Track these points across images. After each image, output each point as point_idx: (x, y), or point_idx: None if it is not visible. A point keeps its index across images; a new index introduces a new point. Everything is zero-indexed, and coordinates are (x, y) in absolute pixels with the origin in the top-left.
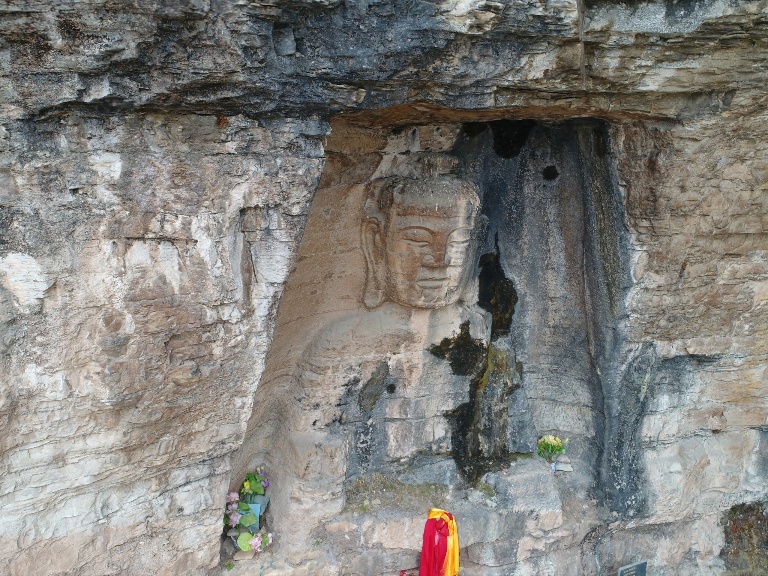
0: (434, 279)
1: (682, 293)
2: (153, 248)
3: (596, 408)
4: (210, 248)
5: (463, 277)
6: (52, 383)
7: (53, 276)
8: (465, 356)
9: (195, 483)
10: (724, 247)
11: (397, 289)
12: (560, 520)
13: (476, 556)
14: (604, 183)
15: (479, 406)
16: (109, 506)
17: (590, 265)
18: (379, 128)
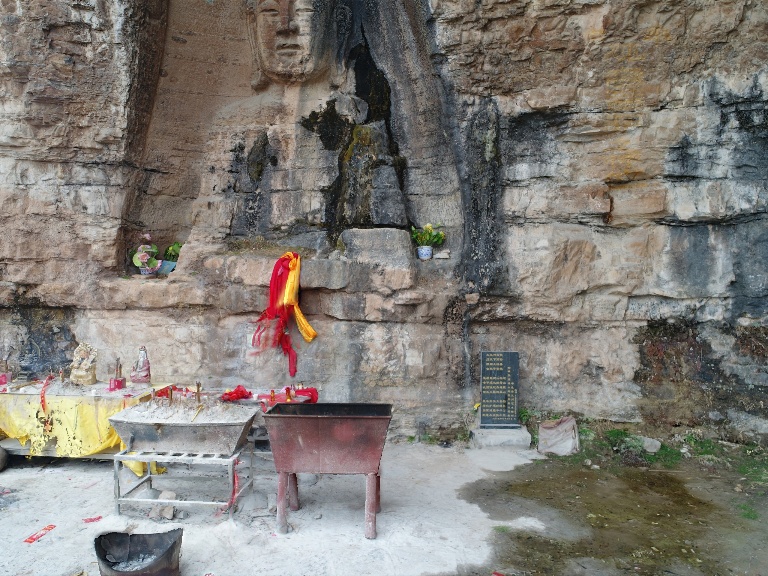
0: (287, 46)
1: (494, 29)
2: None
3: None
4: None
5: (314, 46)
6: None
7: None
8: (332, 130)
9: (95, 187)
10: None
11: (262, 59)
12: (407, 280)
13: (326, 306)
14: None
15: (345, 177)
16: (28, 178)
17: None
18: None
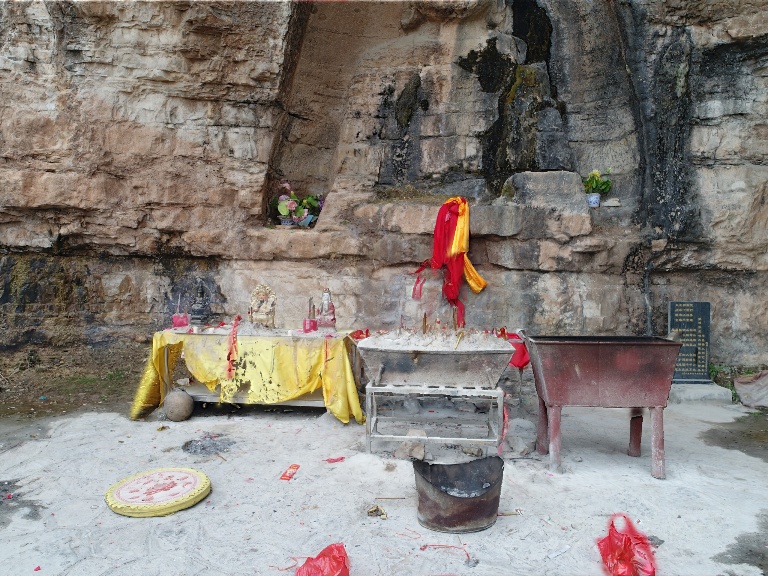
0: None
1: None
2: None
3: (638, 126)
4: None
5: None
6: None
7: None
8: (492, 70)
9: (243, 128)
10: None
11: None
12: (587, 225)
13: (494, 255)
14: None
15: (507, 120)
16: (177, 117)
17: None
18: None
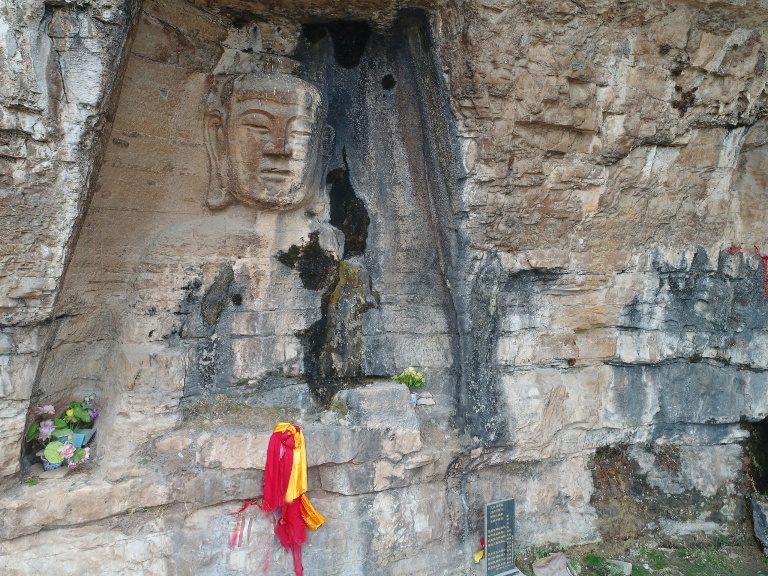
0: (276, 170)
1: (515, 194)
2: None
3: (452, 331)
4: (7, 34)
5: (307, 174)
6: None
7: None
8: (315, 267)
9: None
10: (545, 143)
11: (239, 180)
12: (418, 442)
13: (329, 482)
14: (432, 76)
15: (331, 322)
16: None
17: (430, 170)
18: (217, 13)
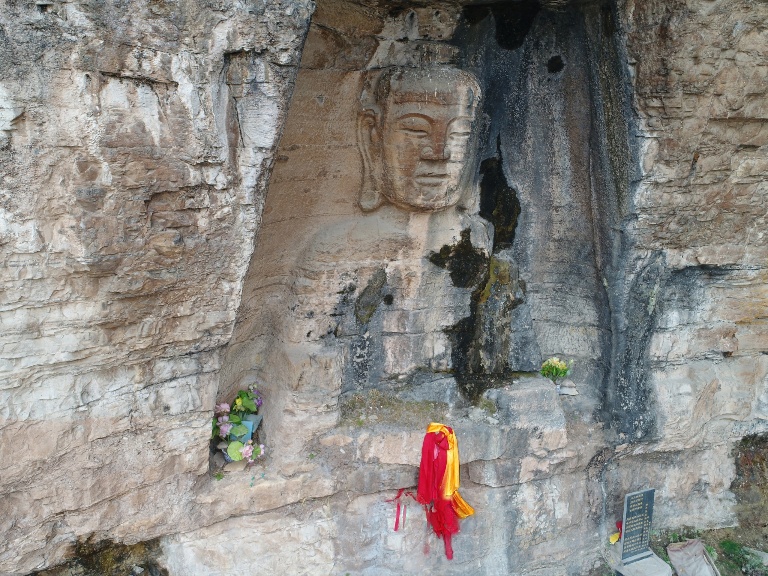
0: (433, 175)
1: (693, 191)
2: (131, 90)
3: (602, 326)
4: (192, 94)
5: (464, 175)
6: (23, 232)
7: (21, 104)
8: (466, 266)
9: (182, 379)
10: (738, 137)
11: (394, 186)
12: (565, 439)
13: (477, 475)
14: (612, 66)
15: (480, 320)
16: (90, 393)
17: (597, 164)
18: (375, 6)
